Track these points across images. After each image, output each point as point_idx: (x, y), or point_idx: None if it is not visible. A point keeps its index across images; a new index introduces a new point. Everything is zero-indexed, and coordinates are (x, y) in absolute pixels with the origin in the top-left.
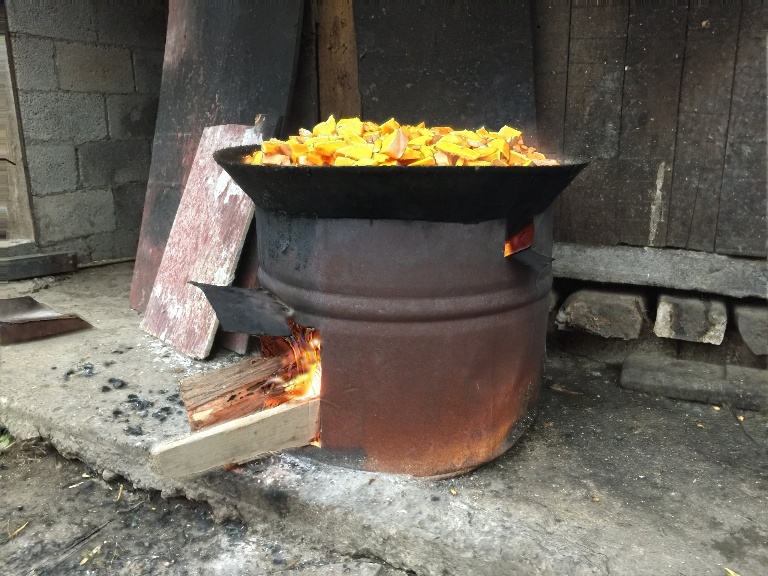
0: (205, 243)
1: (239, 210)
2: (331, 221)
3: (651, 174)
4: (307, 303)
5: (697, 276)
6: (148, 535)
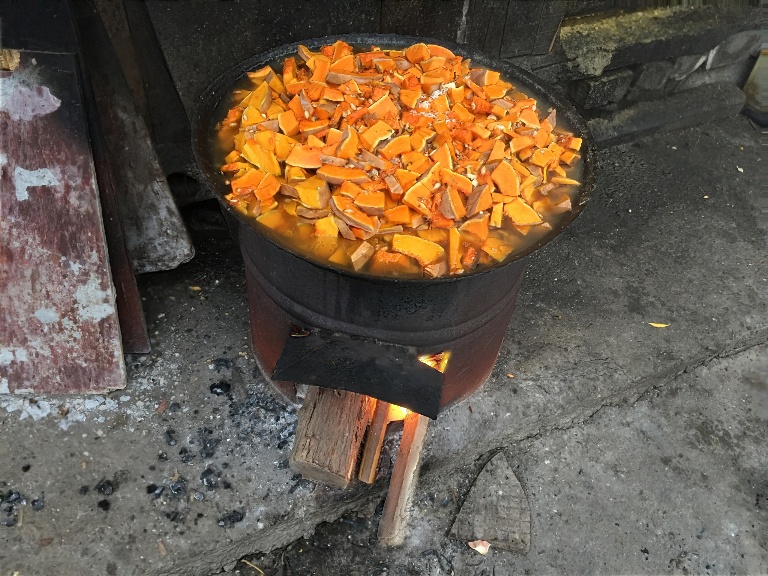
0: (12, 261)
1: (70, 207)
2: None
3: (459, 3)
4: (439, 340)
5: None
6: (335, 571)
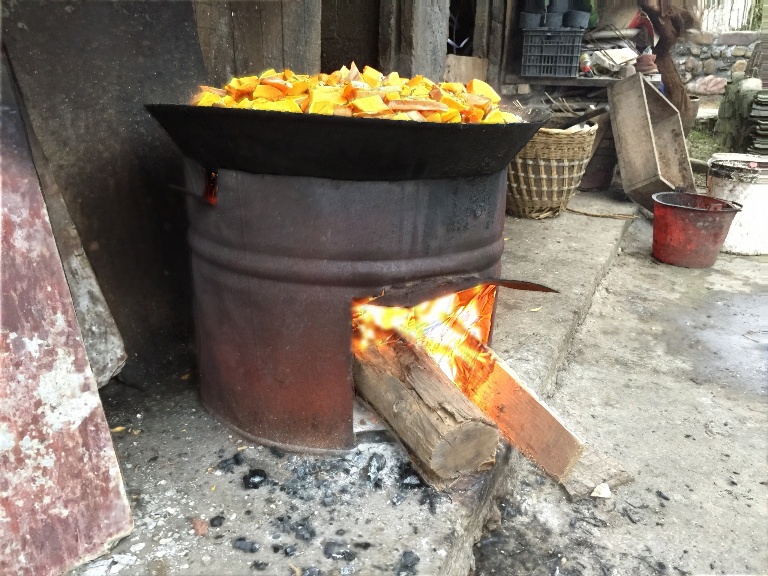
0: None
1: (17, 252)
2: (506, 170)
3: None
4: (493, 257)
5: None
6: None
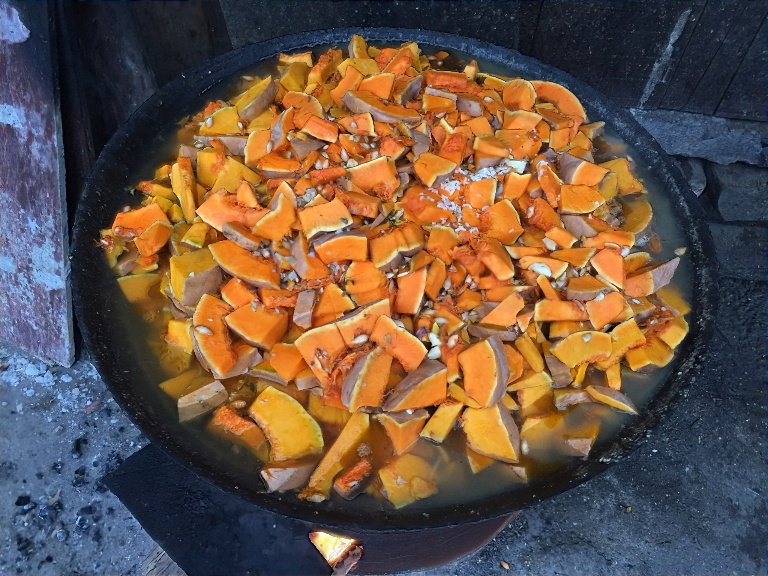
0: None
1: (31, 158)
2: None
3: (667, 24)
4: None
5: (686, 143)
6: None
